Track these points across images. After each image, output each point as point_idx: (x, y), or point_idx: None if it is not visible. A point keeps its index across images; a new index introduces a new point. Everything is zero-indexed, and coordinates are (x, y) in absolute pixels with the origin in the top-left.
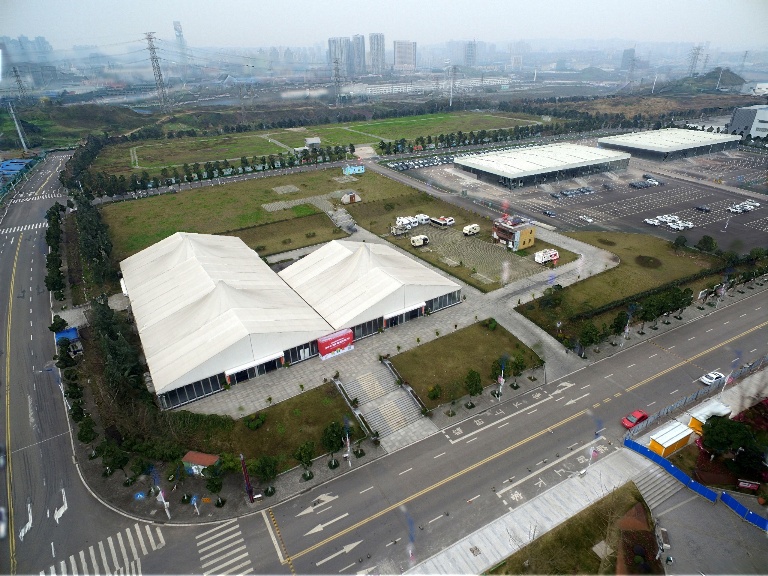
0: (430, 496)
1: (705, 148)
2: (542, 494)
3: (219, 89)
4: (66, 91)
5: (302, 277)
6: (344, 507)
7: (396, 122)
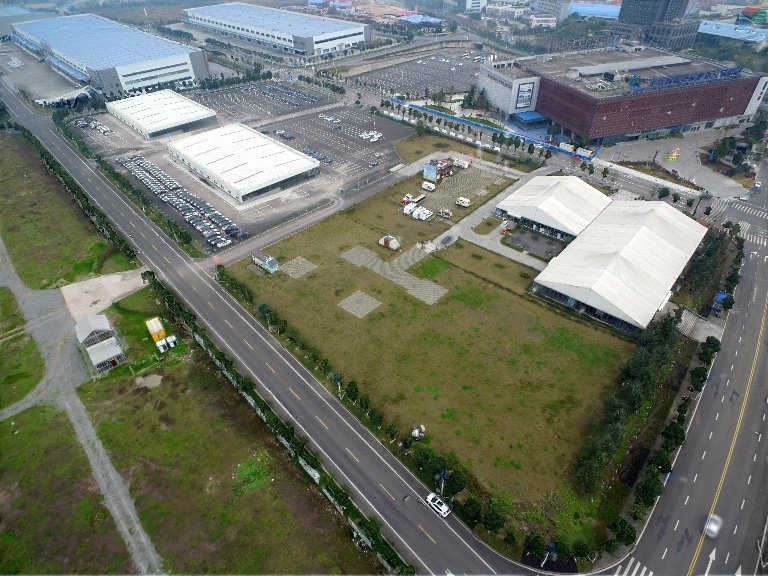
0: (648, 187)
1: None
2: (625, 172)
3: None
4: None
5: (579, 220)
6: (671, 200)
7: None
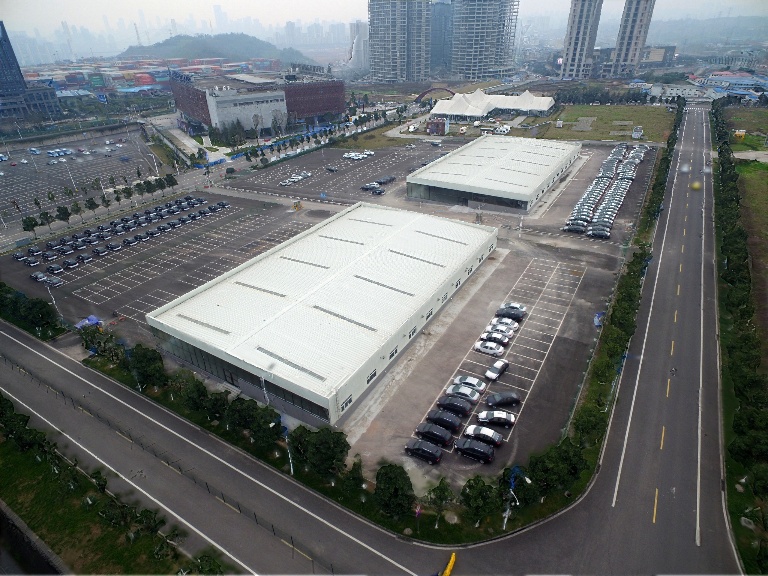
0: None
1: None
2: None
3: None
4: None
5: None
6: None
7: None
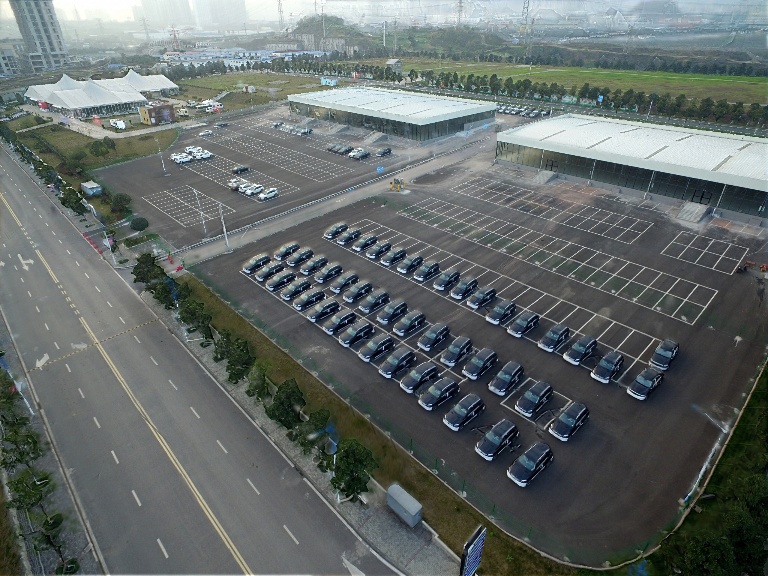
0: None
1: (627, 172)
2: None
3: (611, 25)
4: (481, 20)
5: None
6: None
7: (627, 74)
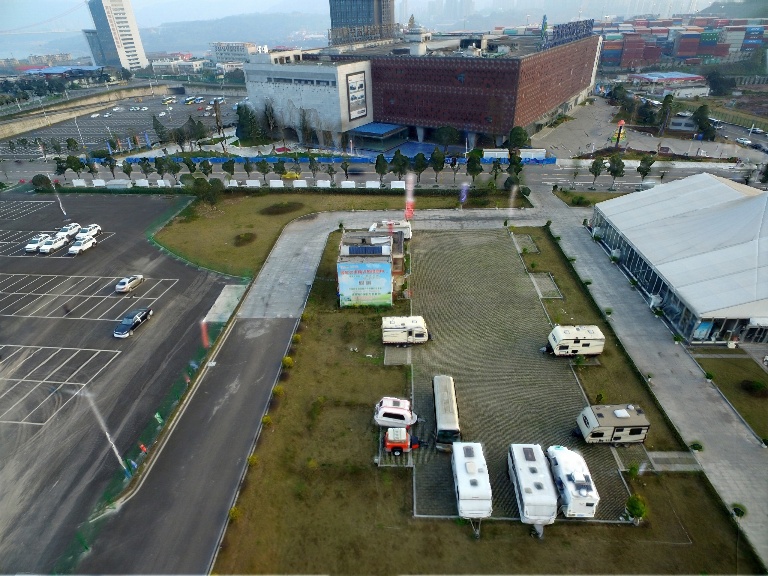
0: None
1: None
2: None
3: None
4: None
5: None
6: (752, 183)
7: None
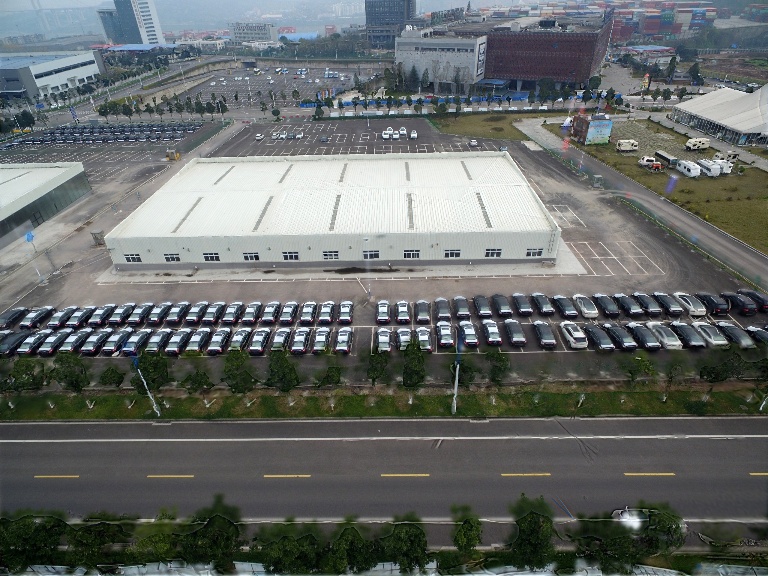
0: None
1: None
2: None
3: None
4: None
5: None
6: None
7: None
